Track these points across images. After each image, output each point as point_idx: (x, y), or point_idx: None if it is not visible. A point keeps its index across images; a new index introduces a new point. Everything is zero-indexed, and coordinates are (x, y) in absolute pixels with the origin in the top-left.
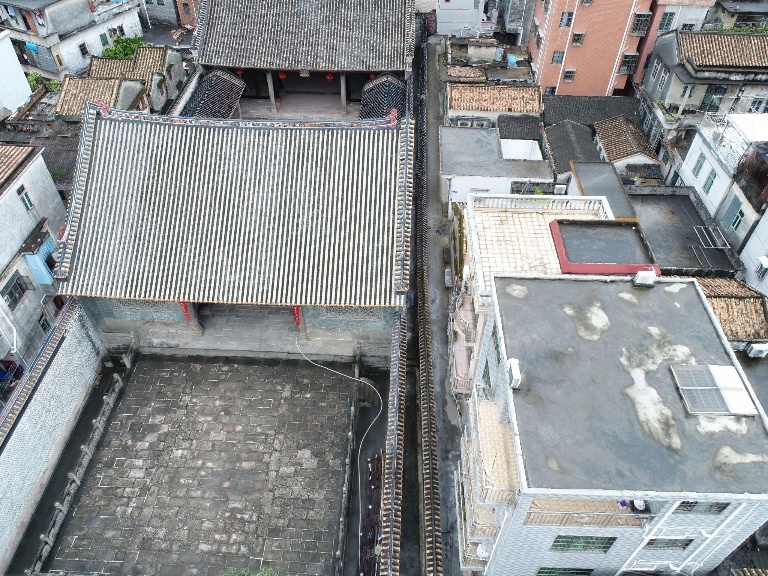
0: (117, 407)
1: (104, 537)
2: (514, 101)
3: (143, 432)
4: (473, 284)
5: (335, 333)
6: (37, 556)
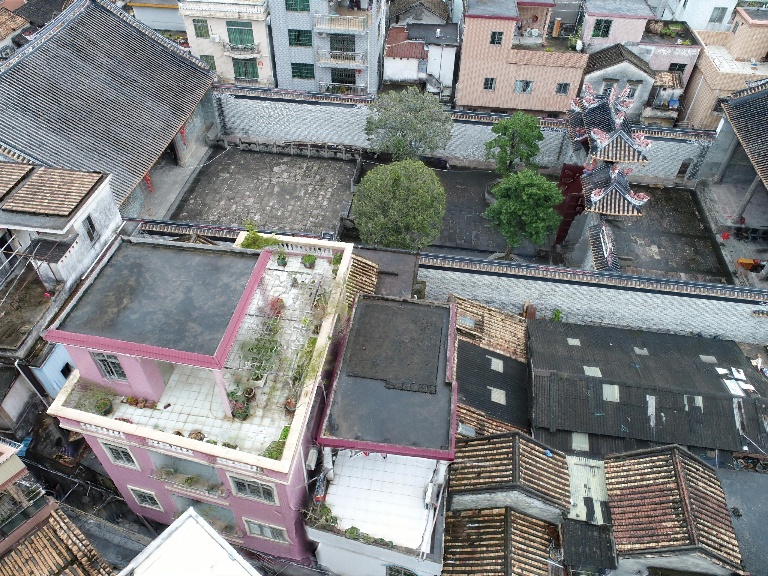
0: None
1: None
2: (7, 24)
3: None
4: (244, 16)
5: None
6: None
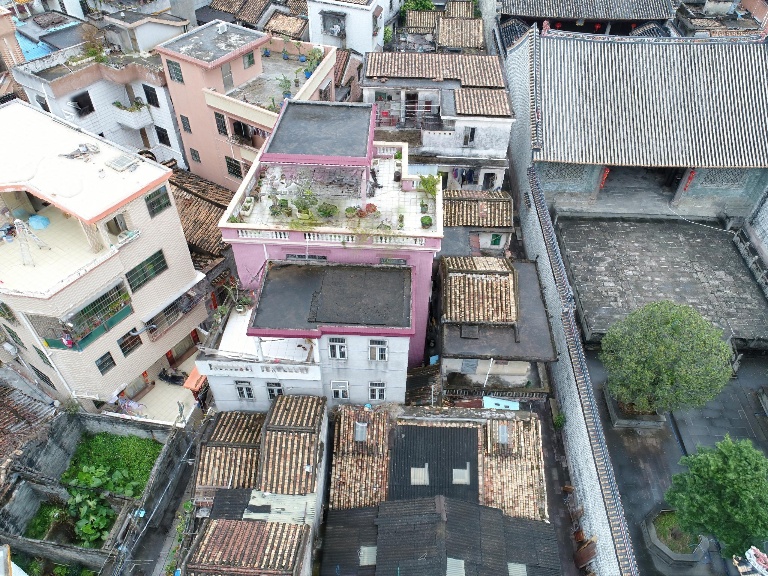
0: None
1: (614, 318)
2: None
3: (595, 261)
4: None
5: (700, 201)
6: (588, 323)
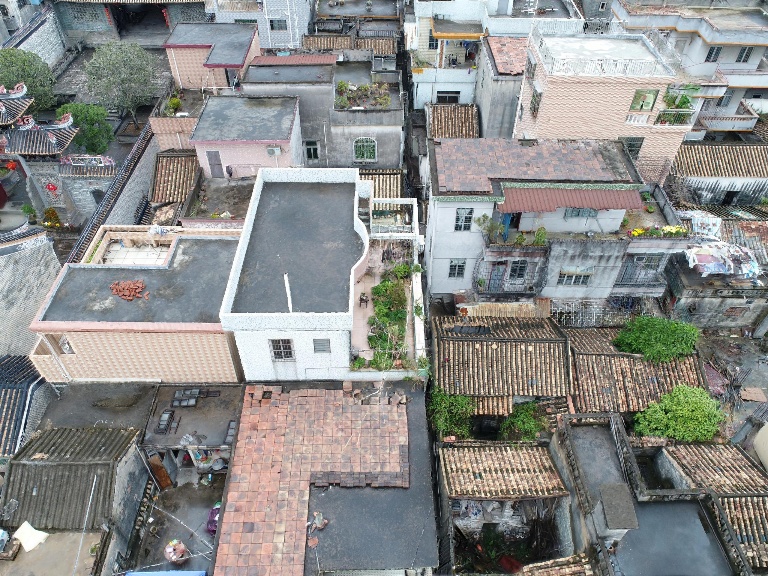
0: (74, 62)
1: (66, 92)
2: None
3: None
4: None
5: None
6: None
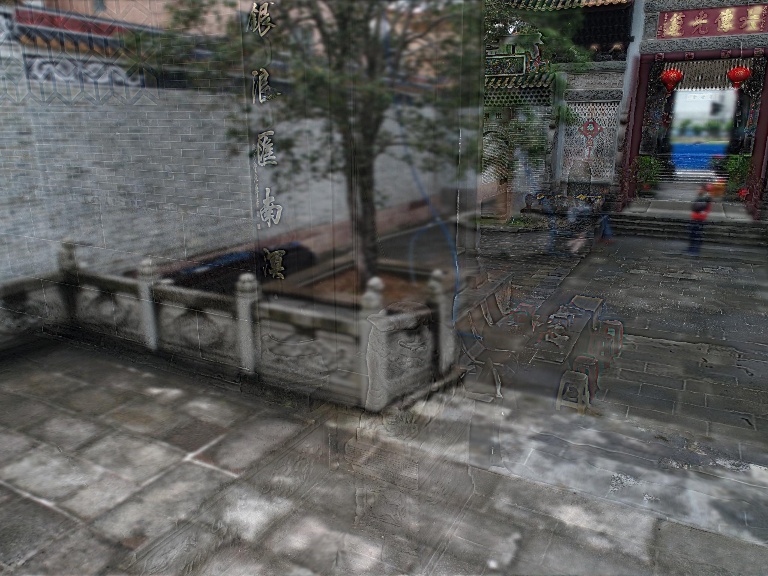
0: None
1: None
2: None
3: None
4: None
5: None
6: None
